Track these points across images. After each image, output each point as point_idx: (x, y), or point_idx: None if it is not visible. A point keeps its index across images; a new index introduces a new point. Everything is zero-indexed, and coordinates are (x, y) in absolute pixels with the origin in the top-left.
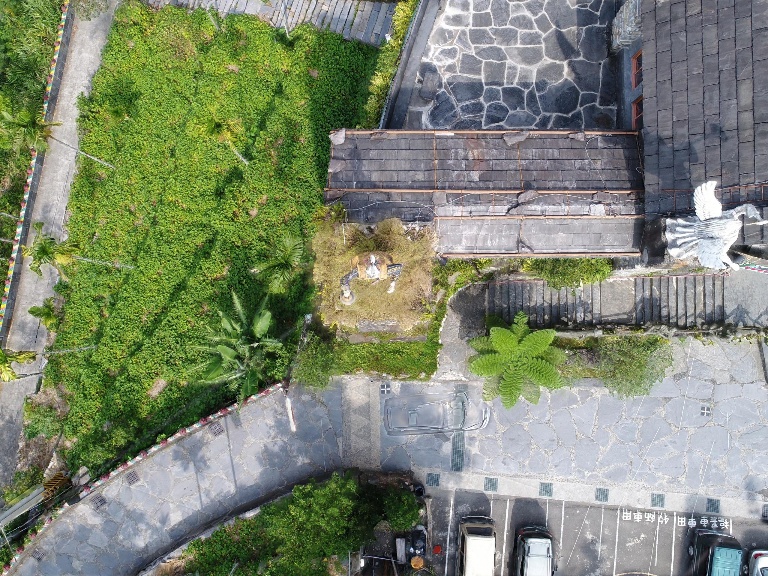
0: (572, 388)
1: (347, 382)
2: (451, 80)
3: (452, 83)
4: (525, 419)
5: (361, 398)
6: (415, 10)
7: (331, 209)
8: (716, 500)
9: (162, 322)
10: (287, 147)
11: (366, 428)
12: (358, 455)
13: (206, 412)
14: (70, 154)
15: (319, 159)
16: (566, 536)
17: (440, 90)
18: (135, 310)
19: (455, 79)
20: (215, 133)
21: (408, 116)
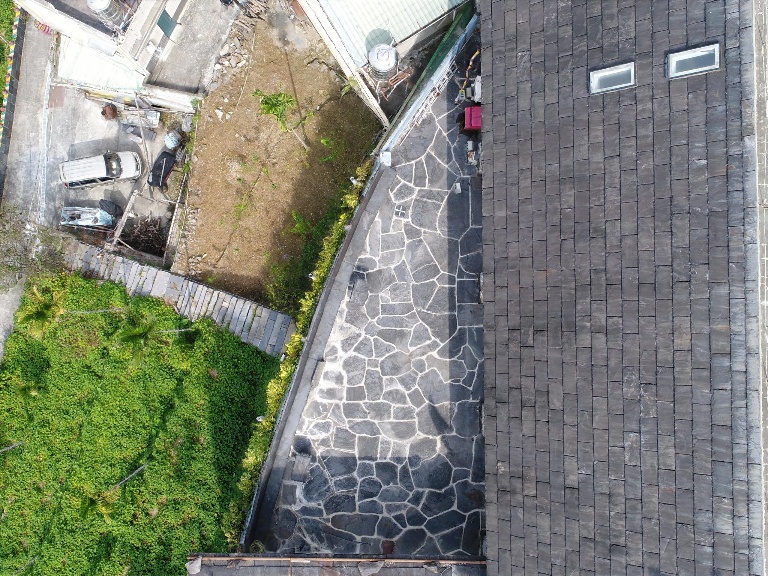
0: None
1: None
2: (325, 454)
3: (326, 457)
4: None
5: None
6: (287, 389)
7: None
8: None
9: None
10: (186, 450)
11: None
12: None
13: None
14: None
15: (218, 461)
16: None
17: (314, 464)
18: None
19: (329, 453)
20: (89, 511)
21: (282, 490)
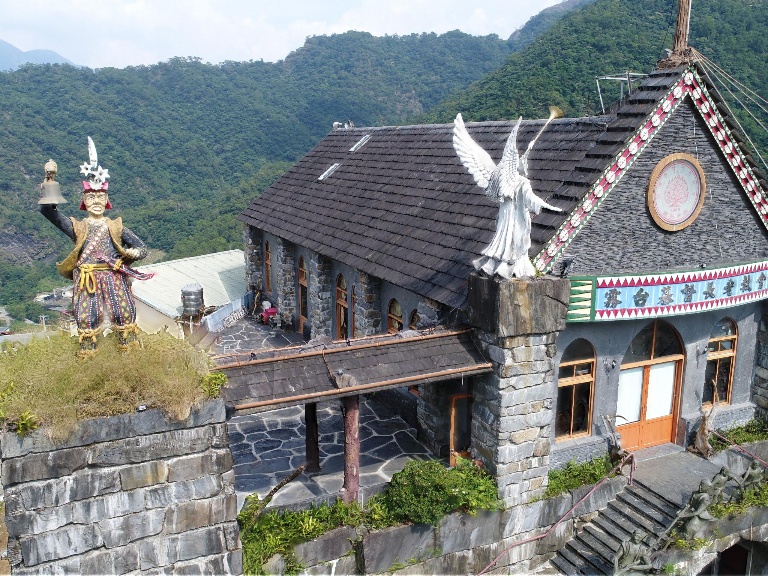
0: None
1: None
2: None
3: None
4: None
5: None
6: None
7: None
8: None
9: None
10: None
11: None
12: None
13: None
14: None
15: None
16: None
17: None
18: None
19: None
20: None
21: None
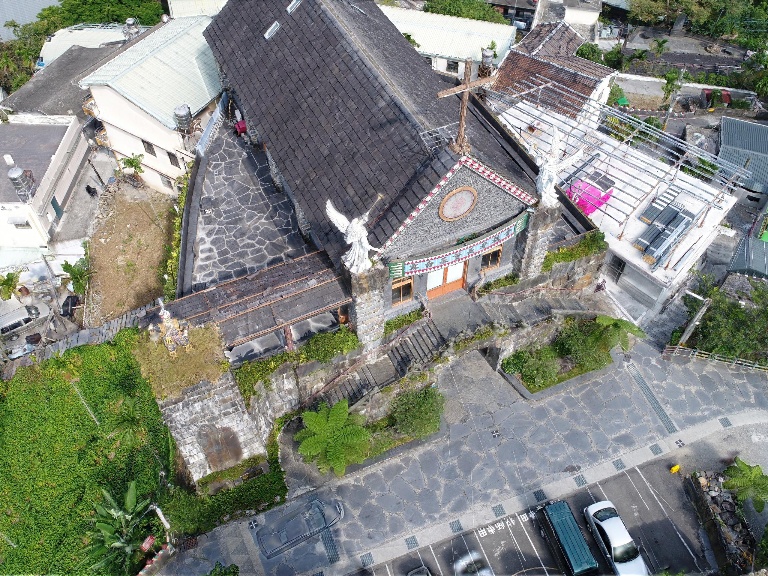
0: (395, 460)
1: (220, 533)
2: None
3: None
4: (371, 497)
5: (235, 540)
6: None
7: None
8: (540, 491)
9: (49, 568)
10: None
11: (248, 562)
12: None
13: None
14: None
15: None
16: (445, 572)
17: None
18: None
19: None
20: (61, 367)
21: None
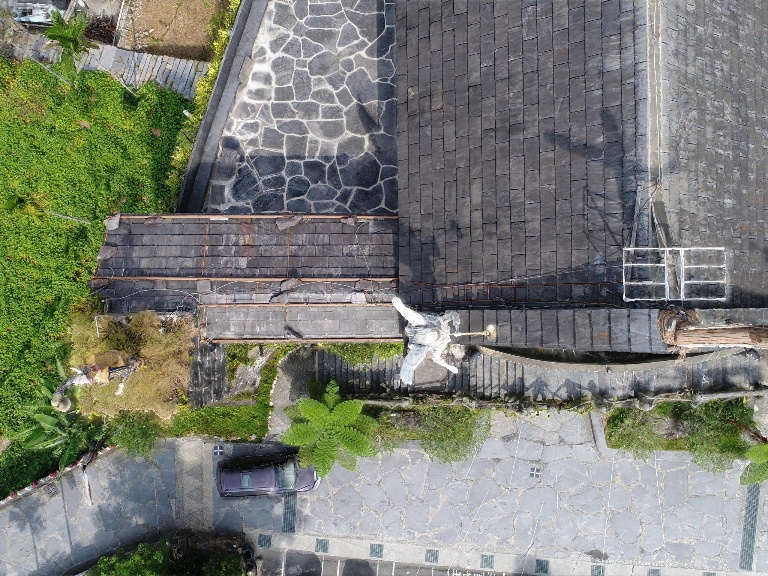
0: (403, 449)
1: (180, 444)
2: (253, 154)
3: (254, 157)
4: (356, 480)
5: (194, 460)
6: None
7: (89, 300)
8: (545, 561)
9: (5, 382)
10: (128, 207)
11: (199, 490)
12: (191, 516)
13: (42, 473)
14: None
15: None
16: None
17: (242, 164)
18: None
19: (257, 153)
20: (17, 208)
21: (211, 190)
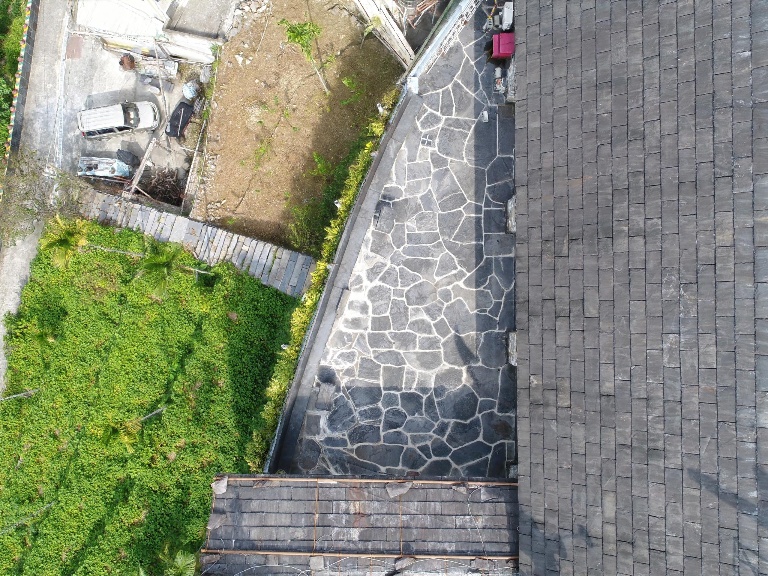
0: None
1: None
2: (349, 384)
3: (350, 387)
4: None
5: None
6: (312, 318)
7: None
8: None
9: (78, 569)
10: (205, 393)
11: None
12: None
13: None
14: (1, 362)
15: (237, 404)
16: None
17: (338, 394)
18: (55, 547)
19: (353, 383)
20: (111, 439)
21: (306, 420)
